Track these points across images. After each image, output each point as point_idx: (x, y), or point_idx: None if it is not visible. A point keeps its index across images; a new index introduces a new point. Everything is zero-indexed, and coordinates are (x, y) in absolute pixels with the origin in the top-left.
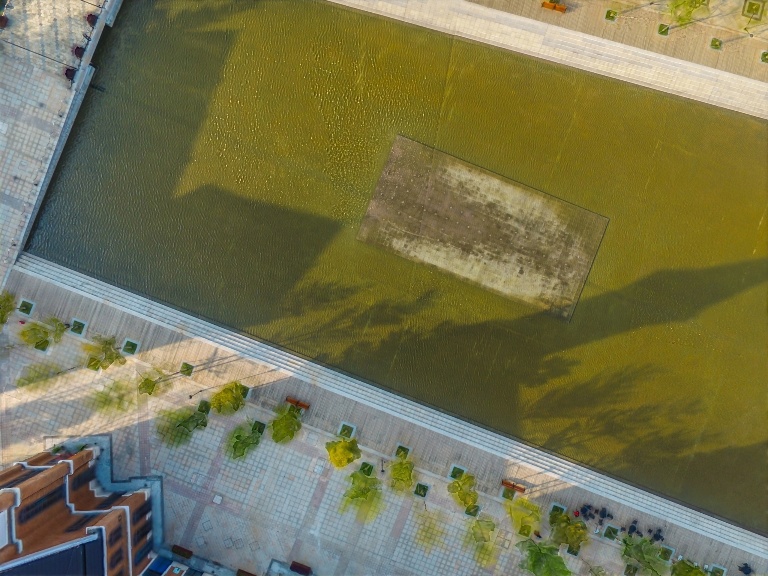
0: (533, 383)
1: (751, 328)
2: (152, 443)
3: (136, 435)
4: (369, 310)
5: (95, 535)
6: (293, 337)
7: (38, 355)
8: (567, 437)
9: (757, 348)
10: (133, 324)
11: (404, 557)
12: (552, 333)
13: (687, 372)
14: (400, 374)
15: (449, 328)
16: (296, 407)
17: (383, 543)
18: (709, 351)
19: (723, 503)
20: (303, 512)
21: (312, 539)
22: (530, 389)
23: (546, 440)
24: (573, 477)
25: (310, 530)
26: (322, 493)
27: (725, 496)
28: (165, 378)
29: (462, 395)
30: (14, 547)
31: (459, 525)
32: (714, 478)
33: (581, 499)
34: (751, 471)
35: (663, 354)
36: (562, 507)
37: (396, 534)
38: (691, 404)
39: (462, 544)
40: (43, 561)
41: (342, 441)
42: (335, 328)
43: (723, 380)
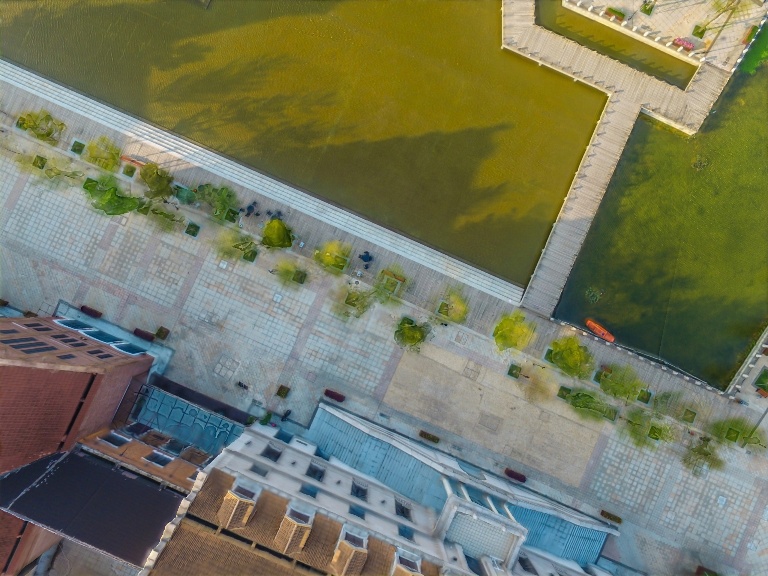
0: (166, 67)
1: (392, 24)
2: None
3: None
4: None
5: None
6: None
7: None
8: (198, 122)
9: (397, 44)
10: None
11: (17, 228)
12: (189, 18)
13: (324, 64)
14: (31, 50)
15: (85, 8)
16: None
17: None
18: (348, 45)
19: (355, 197)
20: None
21: None
22: (163, 72)
23: (176, 124)
24: (198, 159)
25: None
26: None
27: (356, 189)
28: None
29: (93, 75)
30: None
31: (76, 199)
32: (346, 171)
33: (203, 180)
34: (384, 166)
35: (301, 45)
36: (183, 187)
37: (10, 205)
38: (327, 96)
39: (78, 219)
40: None
41: None
42: None
43: (361, 74)
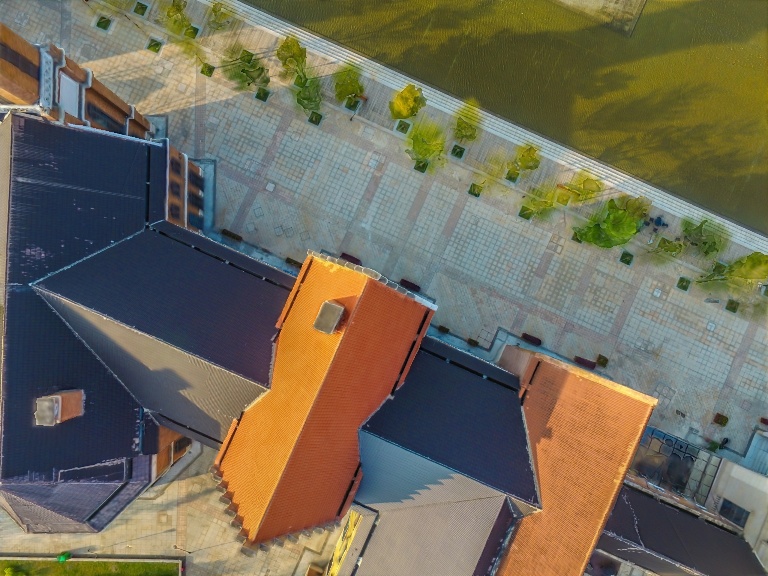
0: (591, 95)
1: None
2: (208, 127)
3: (192, 118)
4: (430, 14)
5: (160, 143)
6: (353, 36)
7: (99, 33)
8: (623, 150)
9: None
10: (196, 9)
11: (455, 256)
12: (612, 47)
13: (746, 93)
14: (458, 78)
15: (509, 36)
16: (354, 99)
17: (434, 241)
18: None
19: None
20: (355, 205)
21: (363, 232)
22: (588, 100)
23: (602, 152)
24: (628, 187)
25: (361, 223)
26: (375, 187)
27: None
28: (224, 64)
29: (520, 103)
30: (83, 123)
31: (512, 227)
32: None
33: None
34: None
35: (723, 74)
36: None
37: (448, 232)
38: (749, 125)
39: (514, 246)
40: (111, 140)
41: (398, 137)
42: (396, 29)
43: None
